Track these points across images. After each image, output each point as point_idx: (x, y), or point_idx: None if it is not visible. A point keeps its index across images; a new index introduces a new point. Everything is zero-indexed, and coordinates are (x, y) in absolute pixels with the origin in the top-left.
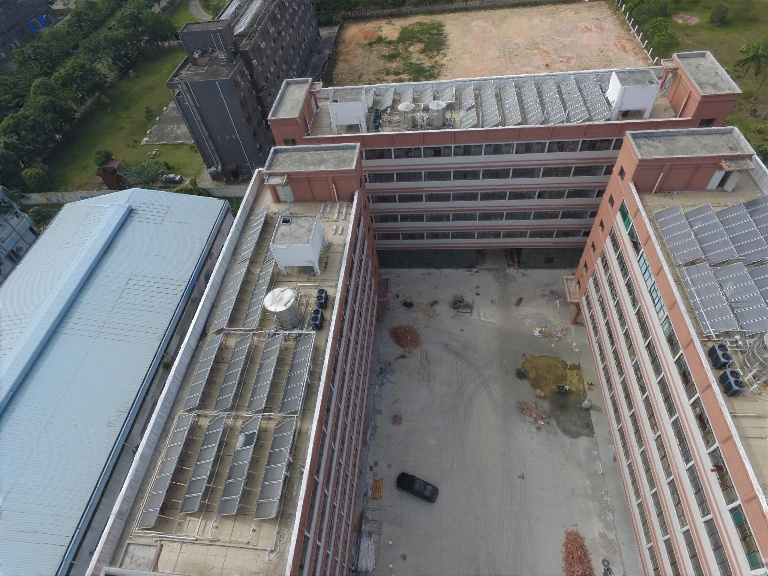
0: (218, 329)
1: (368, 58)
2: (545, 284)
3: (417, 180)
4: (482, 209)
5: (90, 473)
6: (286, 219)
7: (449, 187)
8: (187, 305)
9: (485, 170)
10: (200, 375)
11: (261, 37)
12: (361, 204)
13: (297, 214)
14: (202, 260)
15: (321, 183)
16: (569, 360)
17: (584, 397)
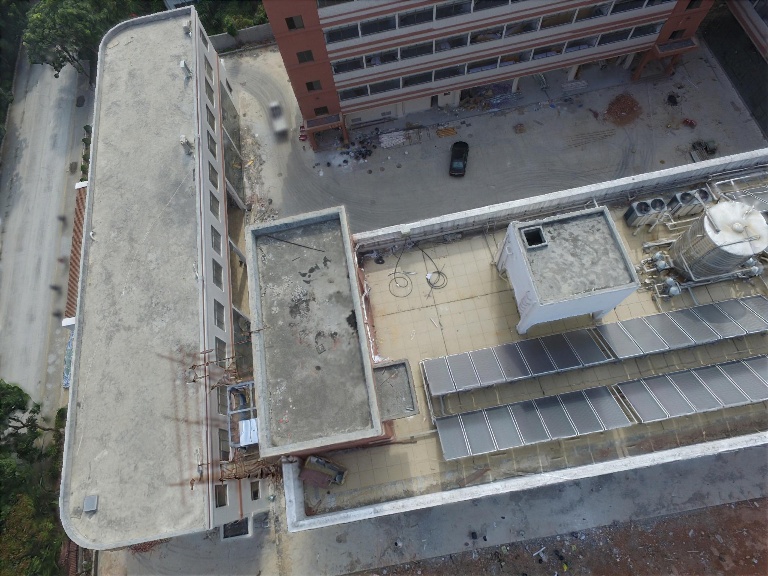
0: None
1: None
2: None
3: None
4: None
5: None
6: None
7: None
8: None
9: None
10: None
11: None
12: None
13: None
14: None
15: None
16: None
17: None
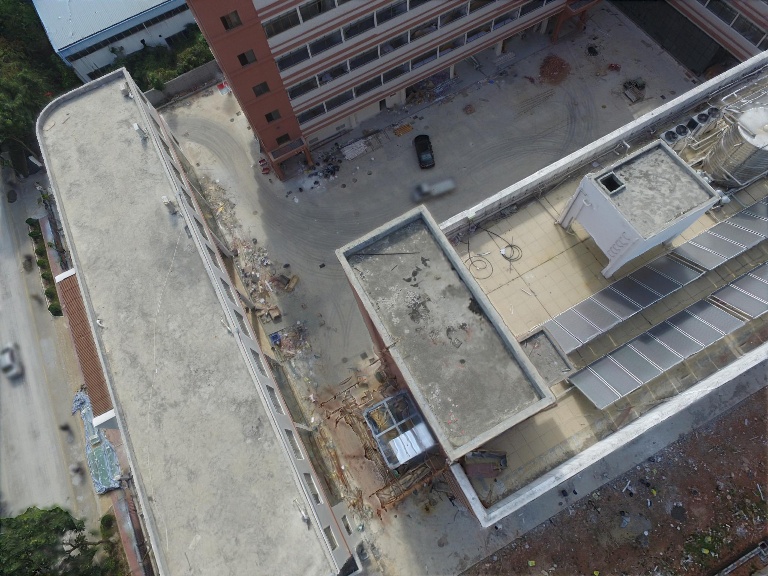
0: None
1: None
2: None
3: None
4: None
5: None
6: None
7: None
8: None
9: None
10: None
11: None
12: None
13: None
14: None
15: None
16: None
17: None
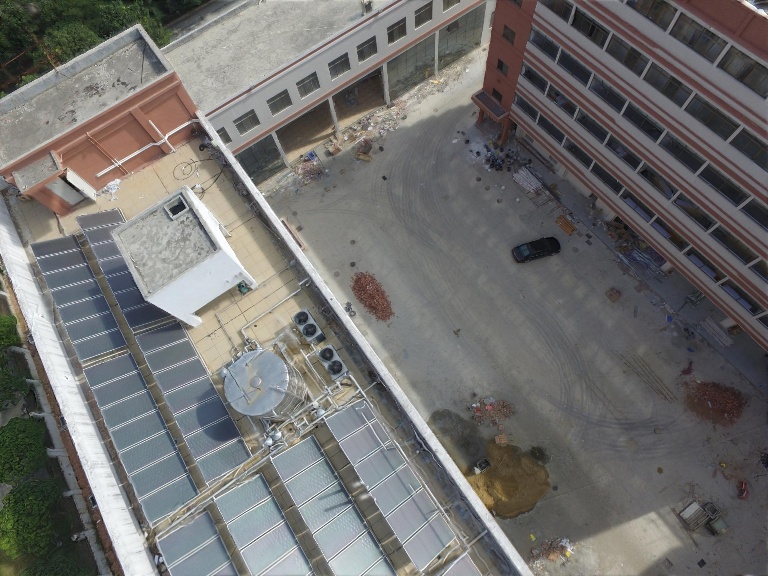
0: None
1: None
2: None
3: None
4: None
5: None
6: None
7: None
8: None
9: None
10: None
11: None
12: None
13: None
14: None
15: None
16: None
17: None
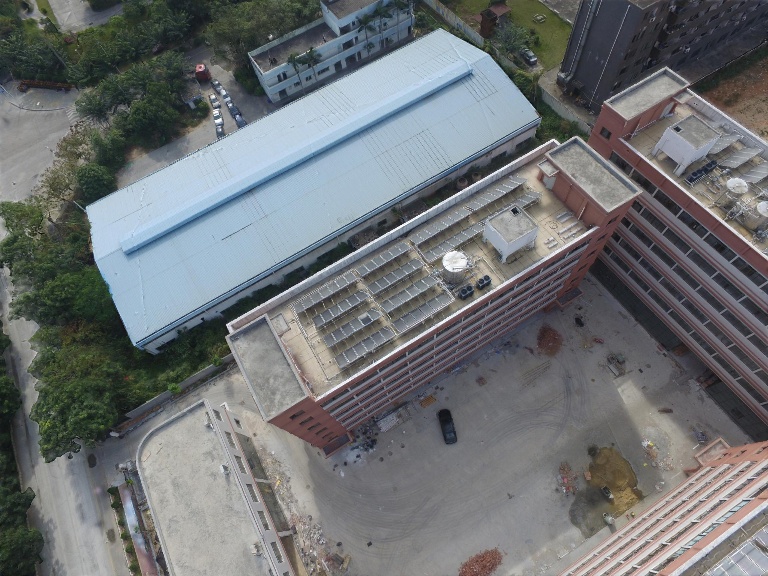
0: (413, 241)
1: None
2: (708, 424)
3: (682, 249)
4: (716, 322)
5: (311, 237)
6: (517, 209)
7: (703, 280)
8: (440, 180)
9: (750, 299)
10: (380, 260)
11: None
12: (595, 236)
13: (541, 203)
14: (478, 155)
15: (578, 197)
16: (642, 486)
17: (616, 515)
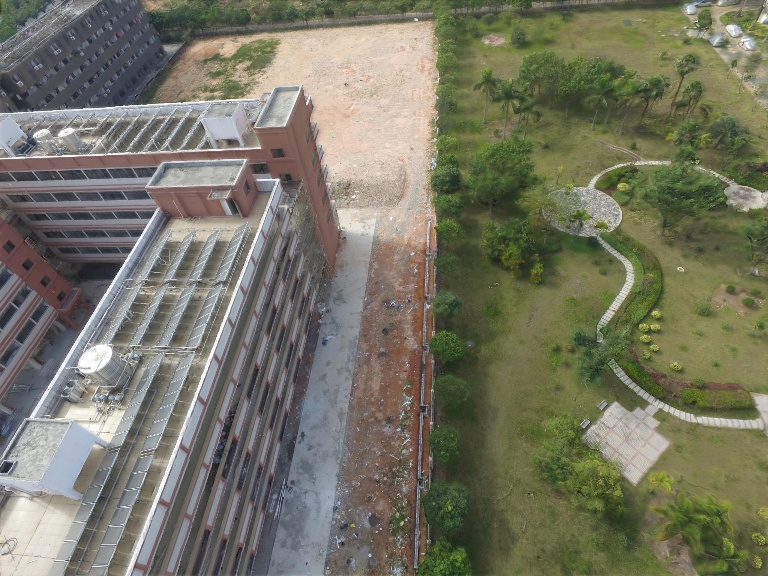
0: None
1: (196, 75)
2: None
3: (75, 200)
4: None
5: None
6: None
7: (106, 206)
8: None
9: (126, 192)
10: None
11: (37, 59)
12: None
13: None
14: None
15: None
16: None
17: None
